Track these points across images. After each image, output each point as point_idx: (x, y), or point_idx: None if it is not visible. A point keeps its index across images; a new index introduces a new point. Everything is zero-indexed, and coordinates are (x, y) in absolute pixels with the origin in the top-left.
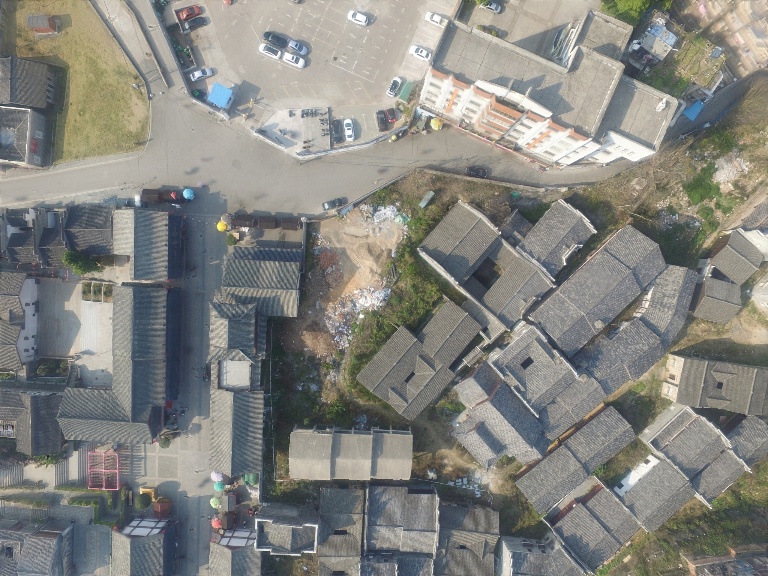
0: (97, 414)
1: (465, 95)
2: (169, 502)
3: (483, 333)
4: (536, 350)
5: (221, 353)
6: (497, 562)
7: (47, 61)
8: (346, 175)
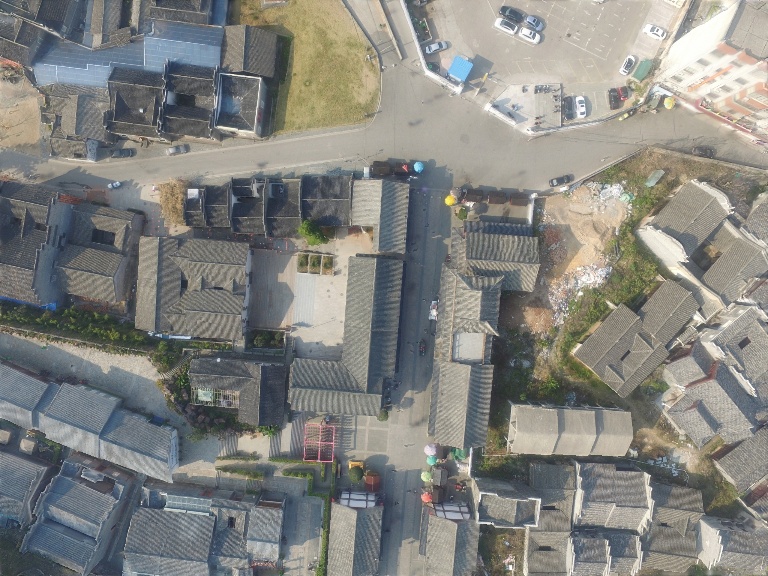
0: (330, 385)
1: (738, 72)
2: (378, 475)
3: (699, 313)
4: (755, 330)
5: (467, 325)
6: None
7: (272, 30)
8: (574, 152)
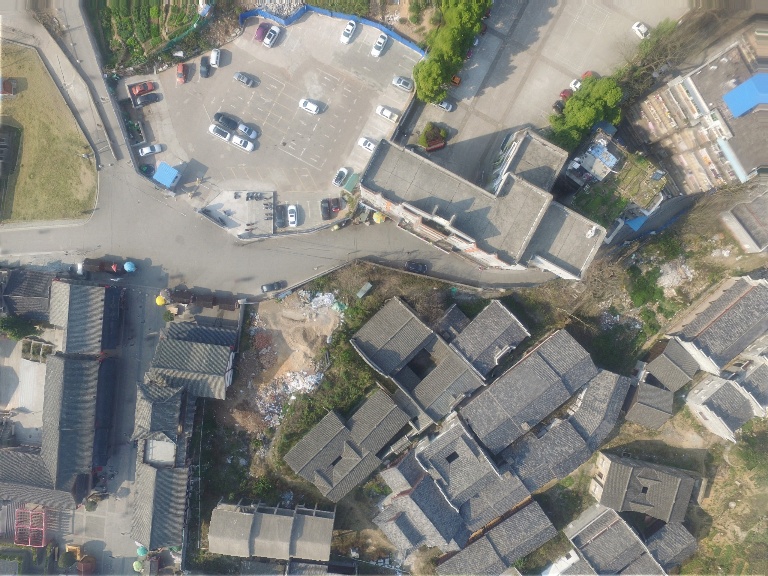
0: (23, 478)
1: (397, 207)
2: (94, 561)
3: (412, 423)
4: (462, 446)
5: (145, 433)
6: None
7: (2, 121)
8: (287, 259)
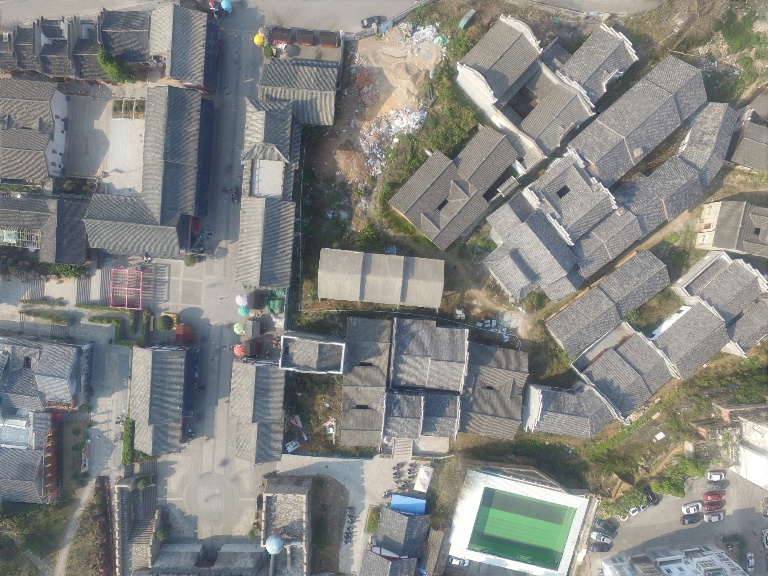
0: (125, 218)
1: None
2: (191, 329)
3: (519, 162)
4: (573, 177)
5: (256, 150)
6: (523, 410)
7: None
8: None
